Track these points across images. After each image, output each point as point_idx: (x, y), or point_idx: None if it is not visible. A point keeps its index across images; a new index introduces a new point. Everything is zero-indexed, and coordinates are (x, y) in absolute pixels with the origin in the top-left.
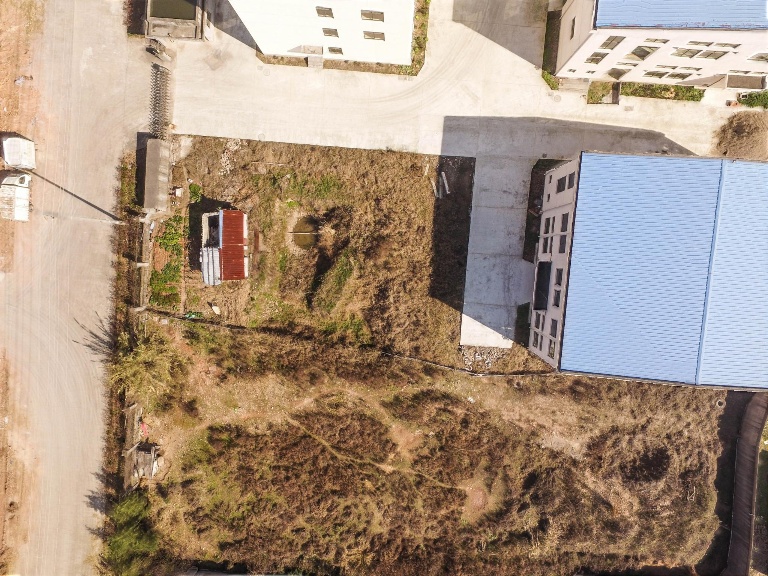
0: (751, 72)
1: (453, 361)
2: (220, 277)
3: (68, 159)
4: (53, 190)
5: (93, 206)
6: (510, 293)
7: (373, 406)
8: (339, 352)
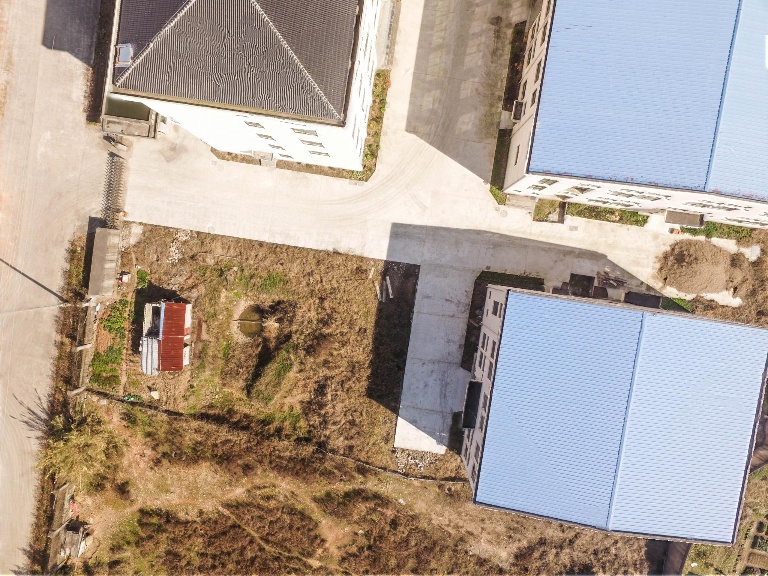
0: (689, 211)
1: (386, 462)
2: (158, 368)
3: (19, 238)
4: (2, 267)
5: (40, 285)
6: (446, 400)
7: (304, 500)
8: (274, 445)
